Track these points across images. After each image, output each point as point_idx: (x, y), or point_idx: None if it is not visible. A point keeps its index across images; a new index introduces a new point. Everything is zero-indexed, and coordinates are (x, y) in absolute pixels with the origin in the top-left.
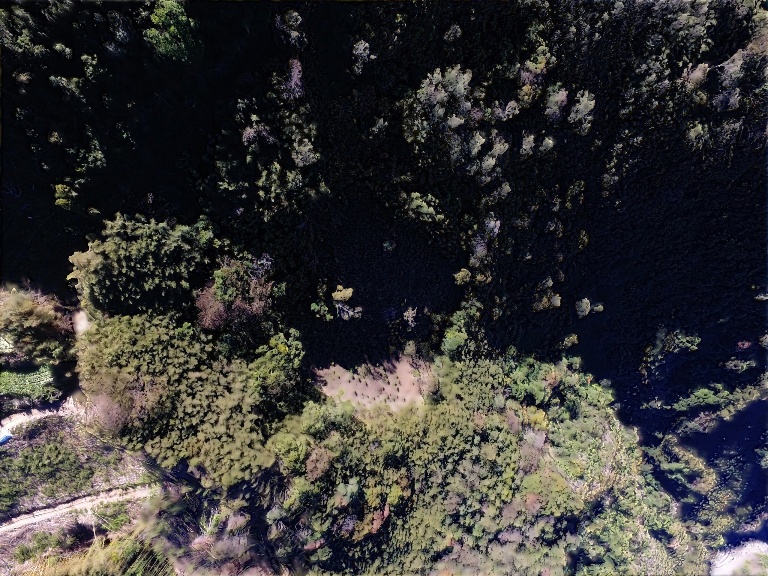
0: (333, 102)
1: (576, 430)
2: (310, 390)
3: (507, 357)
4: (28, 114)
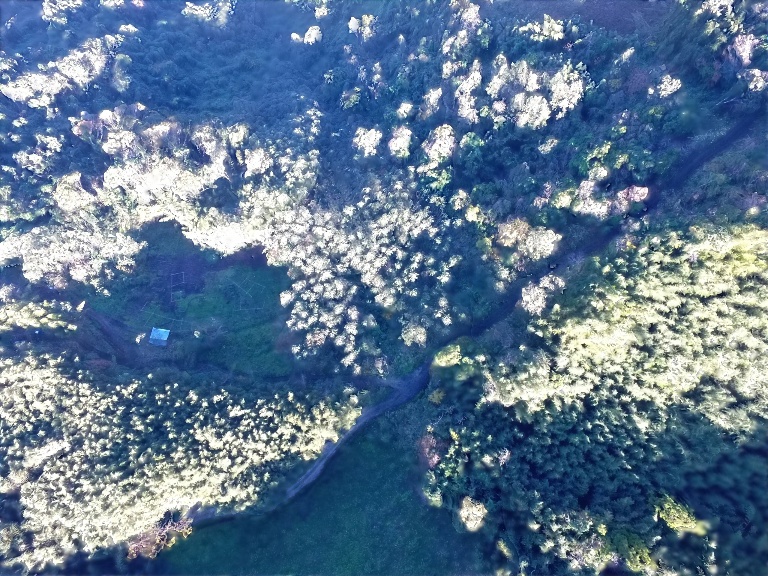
0: None
1: None
2: None
3: None
4: None
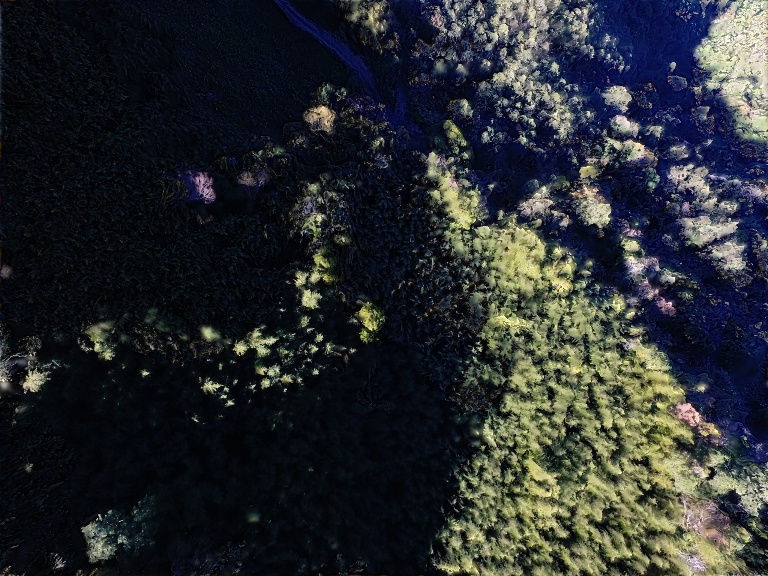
0: None
1: None
2: None
3: (759, 156)
4: None
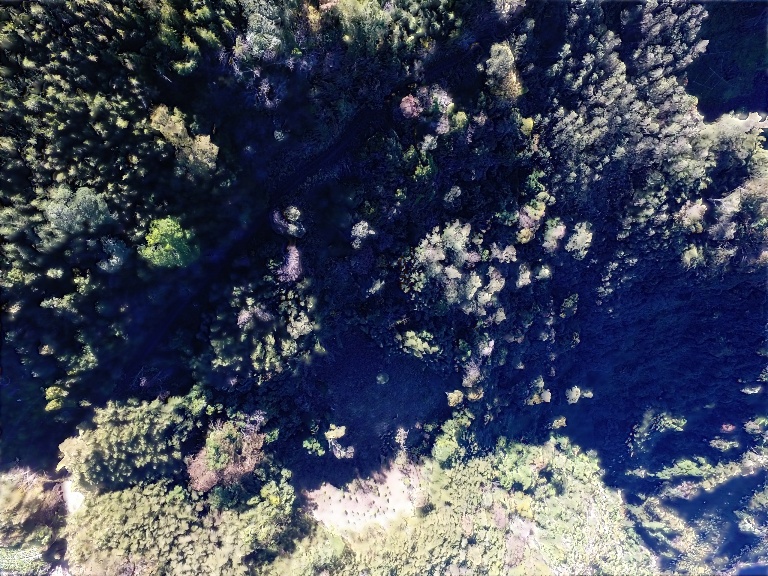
0: (330, 259)
1: (562, 509)
2: (300, 521)
3: (496, 450)
4: (18, 334)
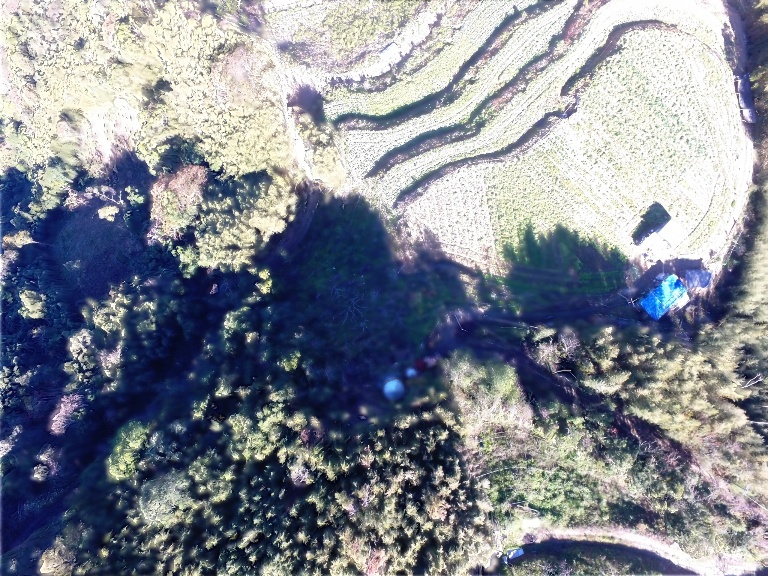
0: None
1: None
2: None
3: None
4: None
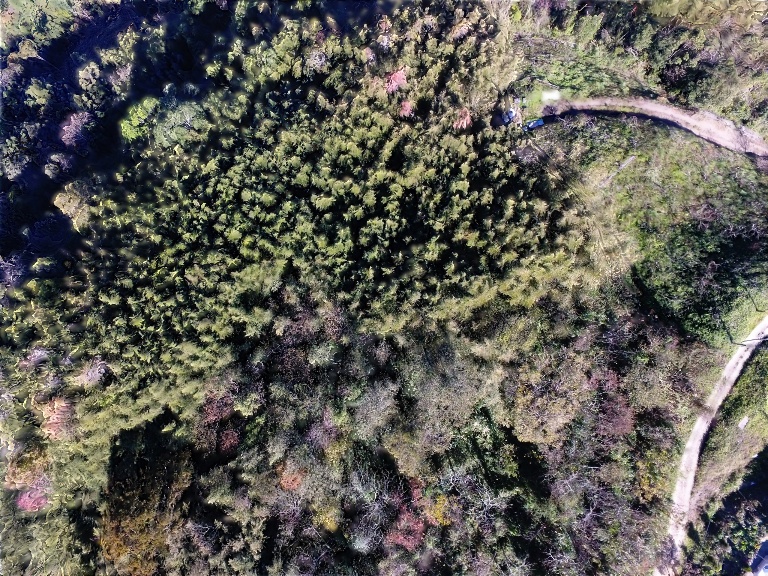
0: None
1: None
2: None
3: None
4: None
